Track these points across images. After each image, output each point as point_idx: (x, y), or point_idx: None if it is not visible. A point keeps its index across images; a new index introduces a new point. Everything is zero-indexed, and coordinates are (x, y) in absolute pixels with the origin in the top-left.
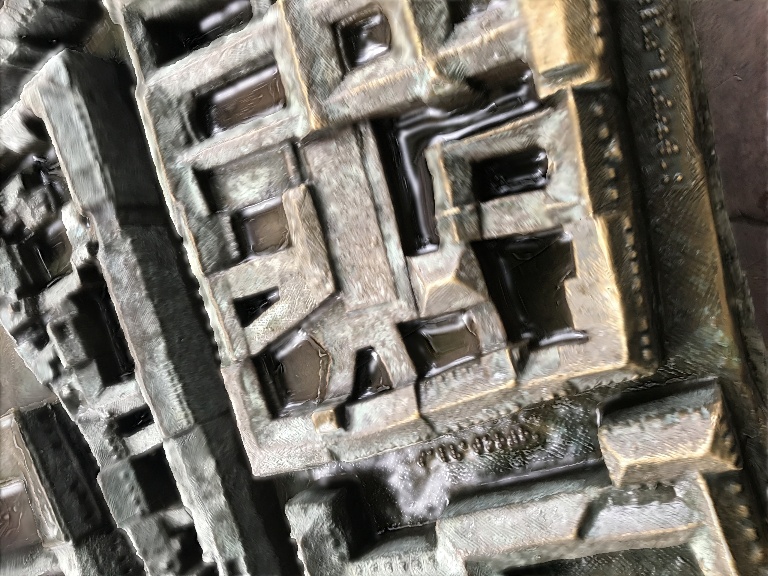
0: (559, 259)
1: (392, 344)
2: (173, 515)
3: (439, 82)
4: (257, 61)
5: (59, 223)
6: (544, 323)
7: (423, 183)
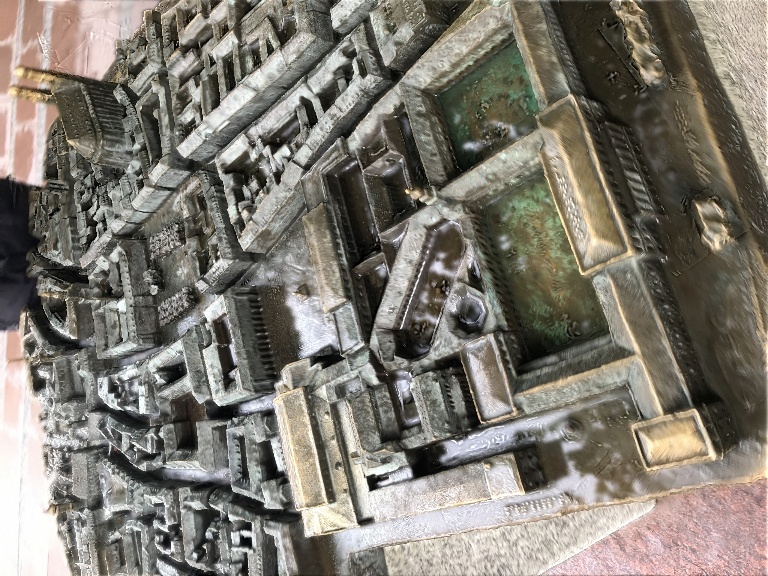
0: None
1: None
2: (341, 88)
3: None
4: (224, 64)
5: (263, 177)
6: None
7: (255, 2)
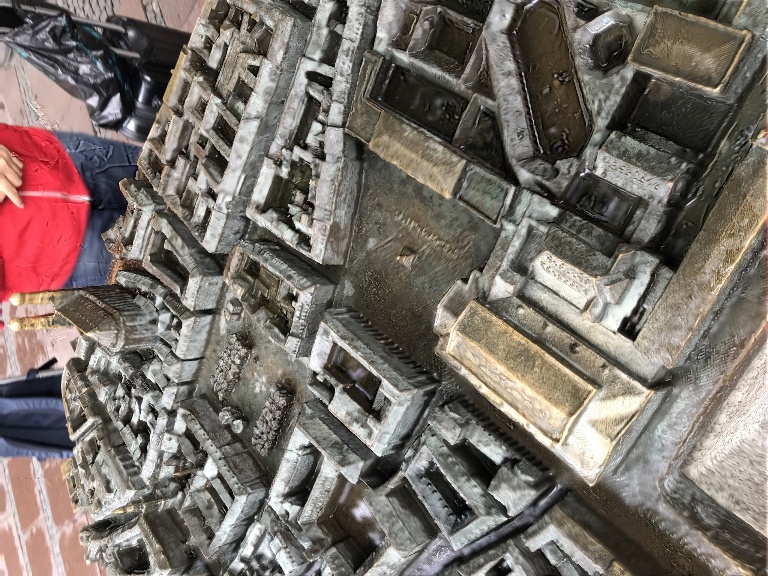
0: (221, 19)
1: (243, 26)
2: (341, 31)
3: (196, 75)
4: (216, 132)
5: None
6: (228, 5)
7: None
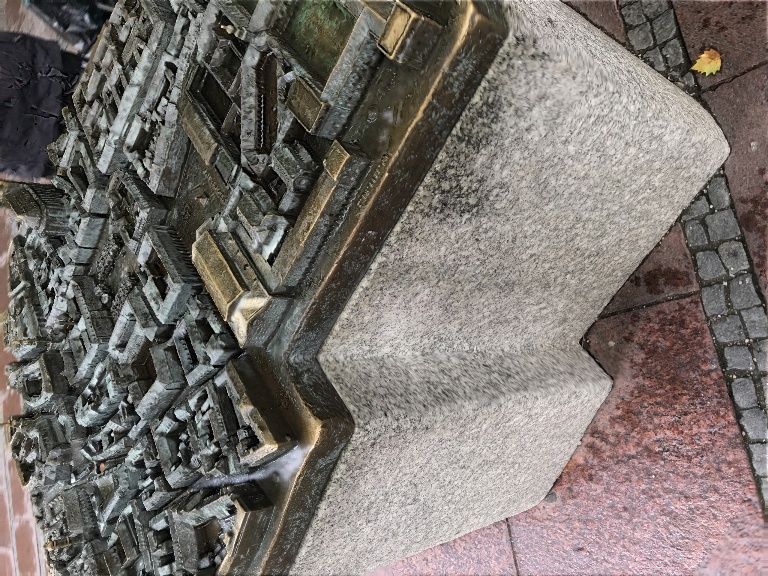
0: (133, 6)
1: None
2: None
3: None
4: None
5: None
6: None
7: None
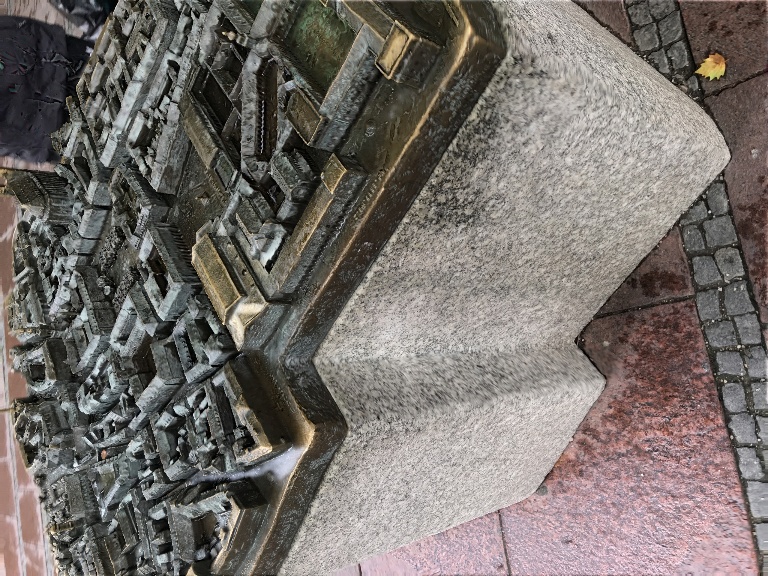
0: None
1: None
2: None
3: None
4: None
5: None
6: None
7: None
